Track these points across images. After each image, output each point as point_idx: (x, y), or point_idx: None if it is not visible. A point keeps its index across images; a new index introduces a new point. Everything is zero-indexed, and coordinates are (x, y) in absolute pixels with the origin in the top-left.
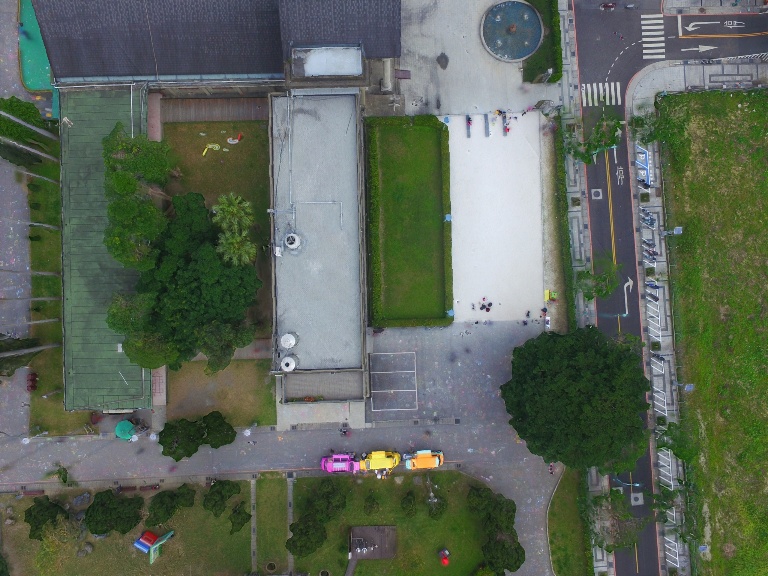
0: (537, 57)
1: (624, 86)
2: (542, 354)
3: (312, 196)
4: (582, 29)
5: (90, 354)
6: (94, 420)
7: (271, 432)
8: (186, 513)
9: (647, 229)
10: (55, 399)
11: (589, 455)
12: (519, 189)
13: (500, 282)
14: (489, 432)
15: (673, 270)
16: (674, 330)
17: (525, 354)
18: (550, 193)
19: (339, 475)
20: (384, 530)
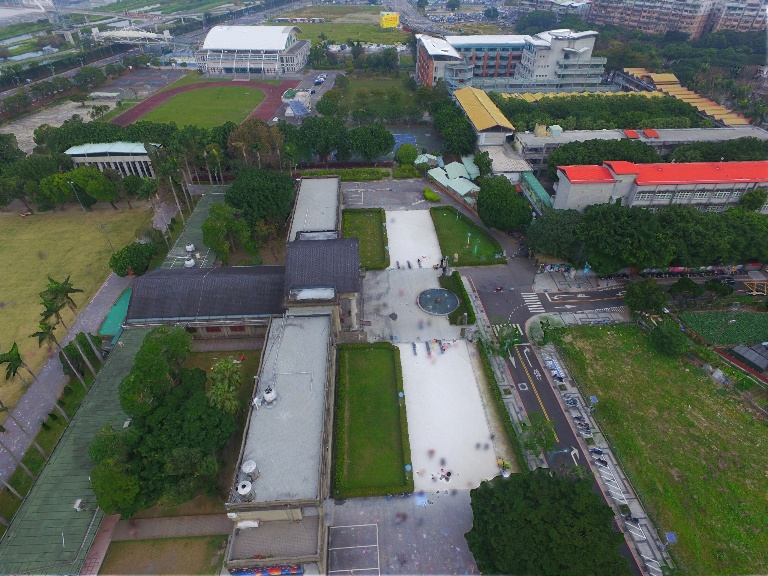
0: (457, 311)
1: (522, 325)
2: (498, 489)
3: (291, 370)
4: (485, 300)
5: (42, 515)
6: None
7: None
8: None
9: (573, 408)
10: None
11: None
12: (459, 386)
13: (455, 455)
14: None
15: (609, 438)
16: (635, 491)
17: (481, 492)
18: (485, 387)
19: None
20: None
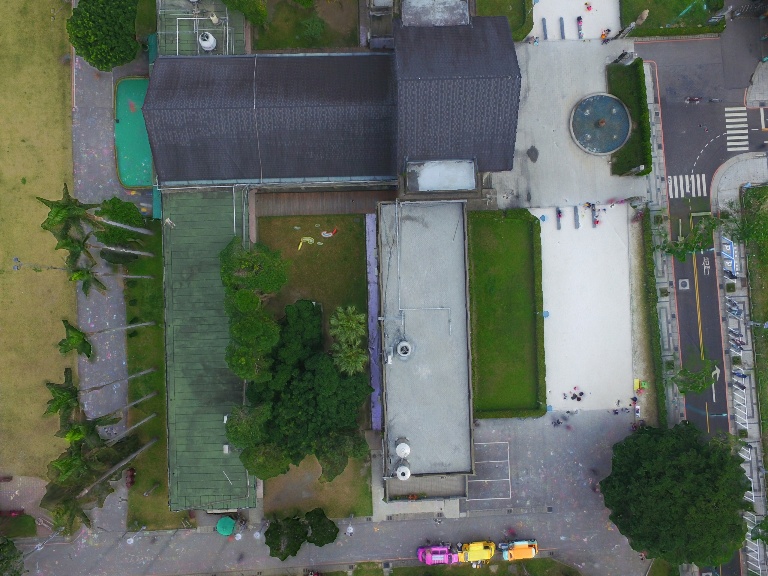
0: (626, 151)
1: (709, 178)
2: (644, 453)
3: (420, 302)
4: (668, 122)
5: (194, 454)
6: (192, 515)
7: (367, 523)
8: None
9: (734, 319)
10: (152, 493)
11: (694, 555)
12: (608, 280)
13: (590, 371)
14: (581, 520)
15: (759, 359)
16: (761, 418)
17: (627, 453)
18: (639, 284)
19: None
20: None
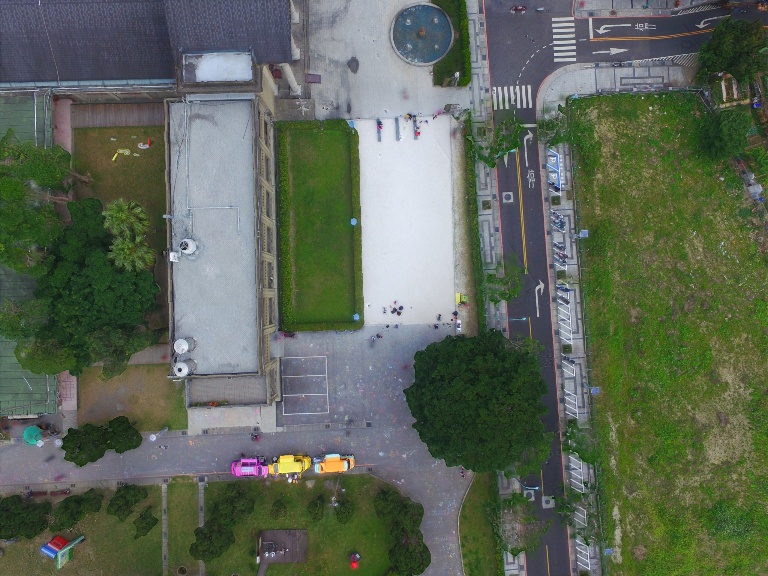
0: (446, 61)
1: (535, 89)
2: (442, 358)
3: (209, 201)
4: (493, 32)
5: None
6: (4, 425)
7: (182, 436)
8: (97, 518)
9: (558, 232)
10: None
11: (486, 459)
12: (430, 193)
13: (411, 286)
14: (400, 435)
15: (584, 273)
16: (585, 333)
17: (426, 358)
18: (461, 196)
19: (250, 479)
20: (295, 534)
